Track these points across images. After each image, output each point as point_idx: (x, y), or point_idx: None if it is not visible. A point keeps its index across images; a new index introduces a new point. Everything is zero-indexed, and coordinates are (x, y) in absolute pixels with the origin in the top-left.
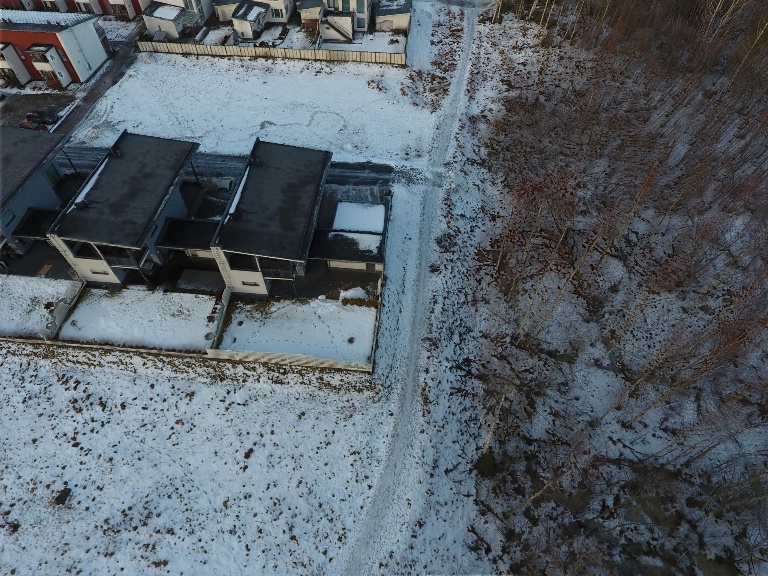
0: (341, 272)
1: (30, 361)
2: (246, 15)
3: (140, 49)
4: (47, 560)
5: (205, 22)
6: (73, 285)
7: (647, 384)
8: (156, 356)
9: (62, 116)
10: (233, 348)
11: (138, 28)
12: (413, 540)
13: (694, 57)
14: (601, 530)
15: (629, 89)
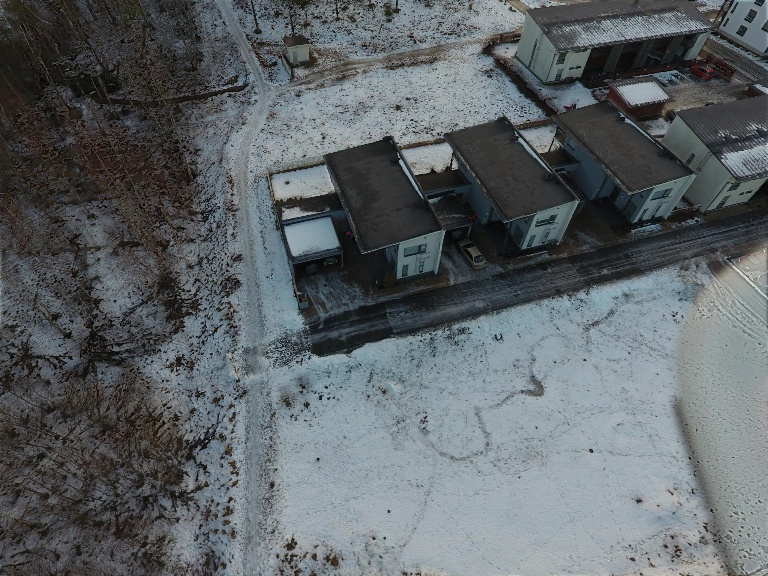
0: None
1: None
2: None
3: None
4: None
5: None
6: None
7: (62, 246)
8: None
9: (767, 295)
10: None
11: None
12: (228, 138)
13: None
14: None
15: None
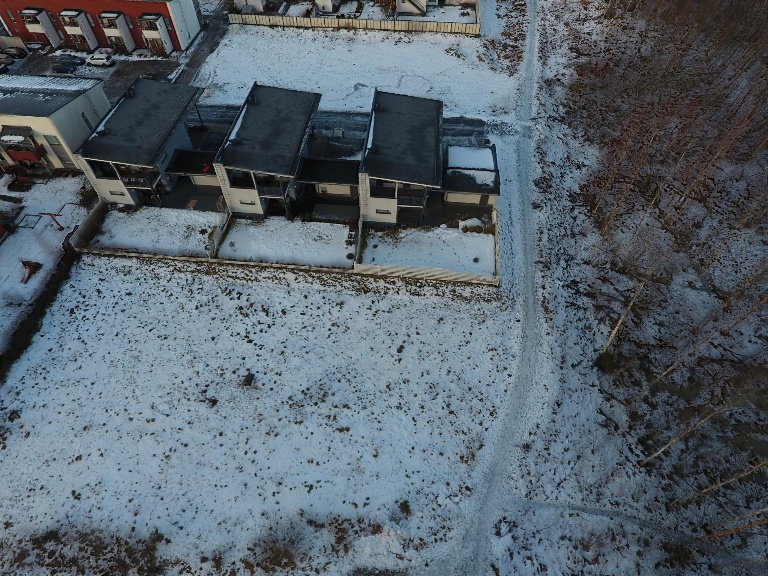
0: (456, 206)
1: (194, 277)
2: None
3: (230, 21)
4: (247, 426)
5: None
6: (220, 216)
7: (738, 302)
8: (306, 272)
9: (172, 79)
10: None
11: (222, 3)
12: (554, 416)
13: (751, 26)
14: None
15: (691, 56)
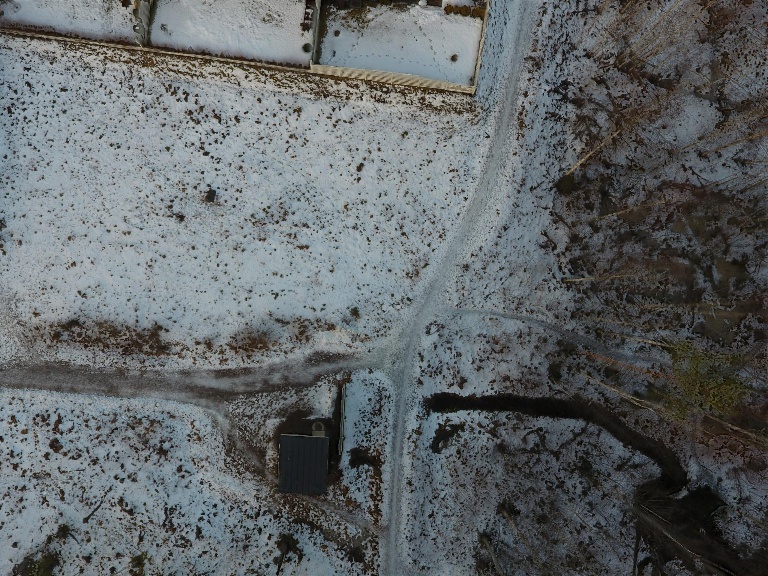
0: None
1: (131, 69)
2: None
3: None
4: (216, 241)
5: None
6: None
7: (738, 115)
8: (257, 69)
9: None
10: (334, 63)
11: None
12: (498, 239)
13: None
14: (649, 238)
15: None
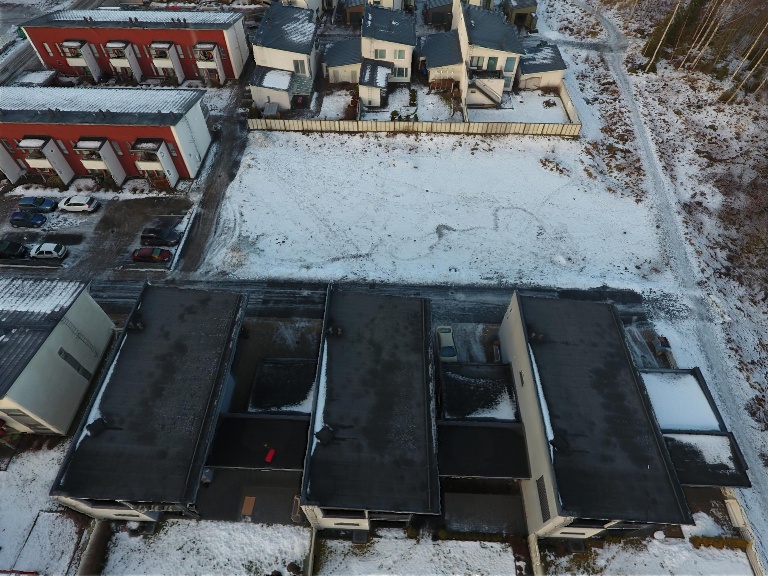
0: None
1: None
2: (374, 80)
3: (249, 127)
4: None
5: (313, 85)
6: (298, 535)
7: None
8: None
9: (183, 232)
10: None
11: (234, 96)
12: None
13: None
14: None
15: None
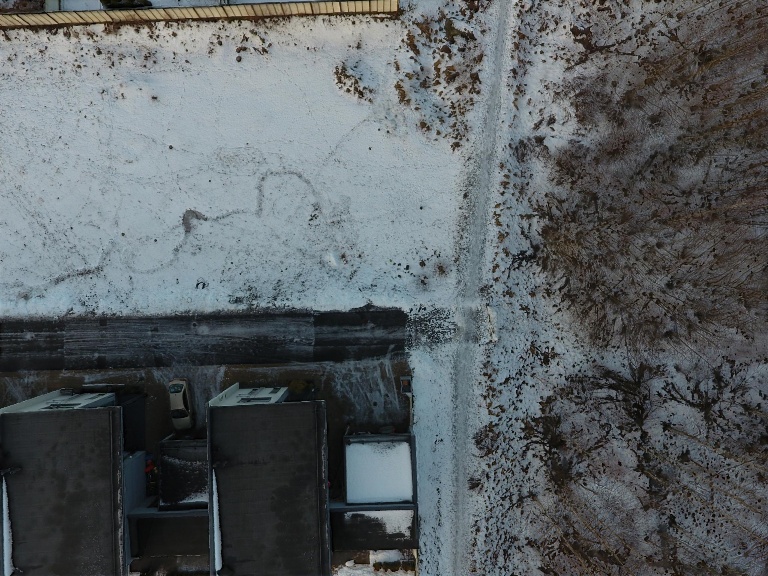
0: None
1: None
2: None
3: None
4: None
5: None
6: None
7: None
8: None
9: None
10: None
11: None
12: None
13: None
14: None
15: None
